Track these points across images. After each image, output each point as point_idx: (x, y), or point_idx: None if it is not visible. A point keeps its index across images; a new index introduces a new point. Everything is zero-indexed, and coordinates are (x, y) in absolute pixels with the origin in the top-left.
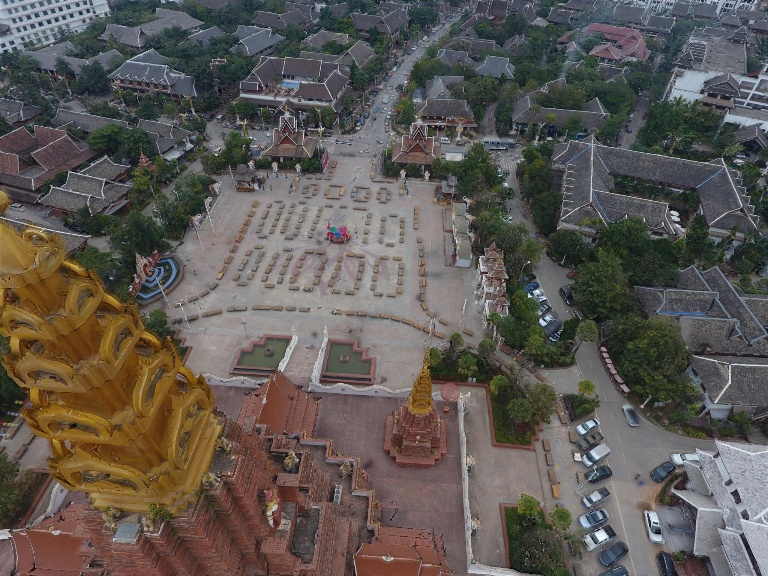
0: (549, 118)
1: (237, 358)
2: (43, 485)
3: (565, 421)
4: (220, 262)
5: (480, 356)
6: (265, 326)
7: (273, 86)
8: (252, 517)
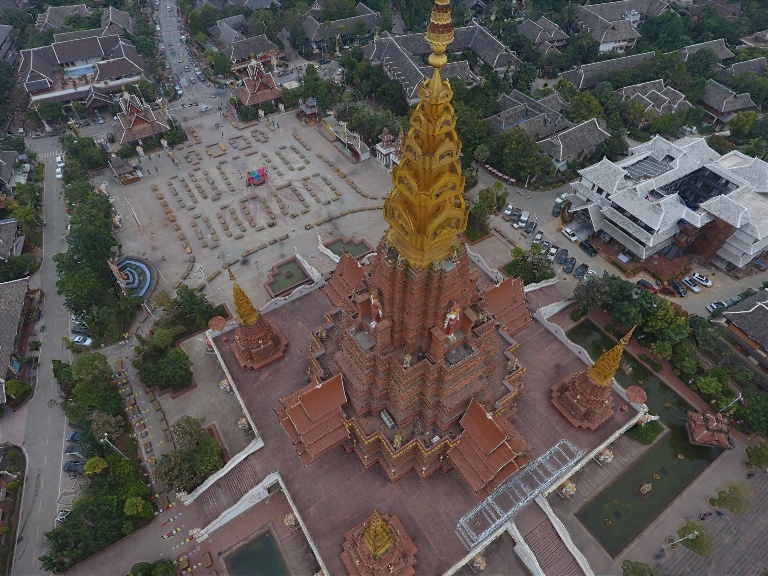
0: (340, 29)
1: (269, 289)
2: (215, 436)
3: (497, 213)
4: (176, 242)
5: None
6: (266, 262)
7: (60, 78)
8: None
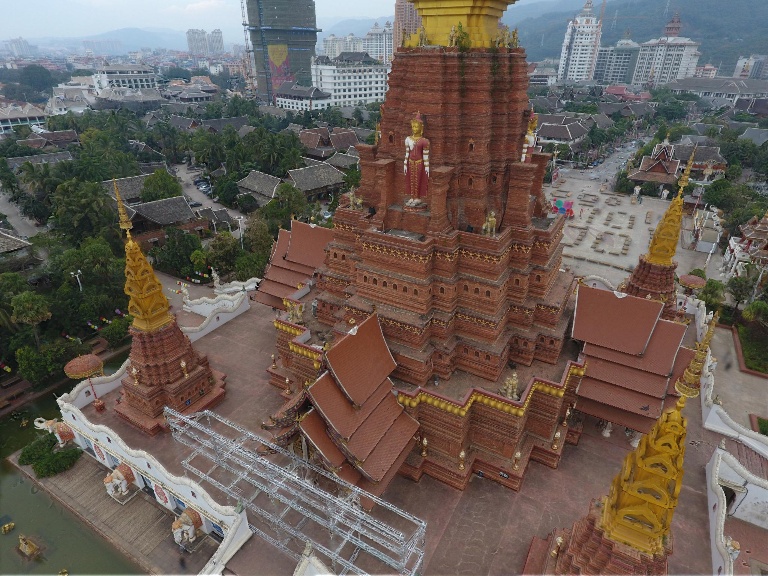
0: None
1: None
2: None
3: None
4: None
5: (730, 287)
6: None
7: None
8: (516, 121)
